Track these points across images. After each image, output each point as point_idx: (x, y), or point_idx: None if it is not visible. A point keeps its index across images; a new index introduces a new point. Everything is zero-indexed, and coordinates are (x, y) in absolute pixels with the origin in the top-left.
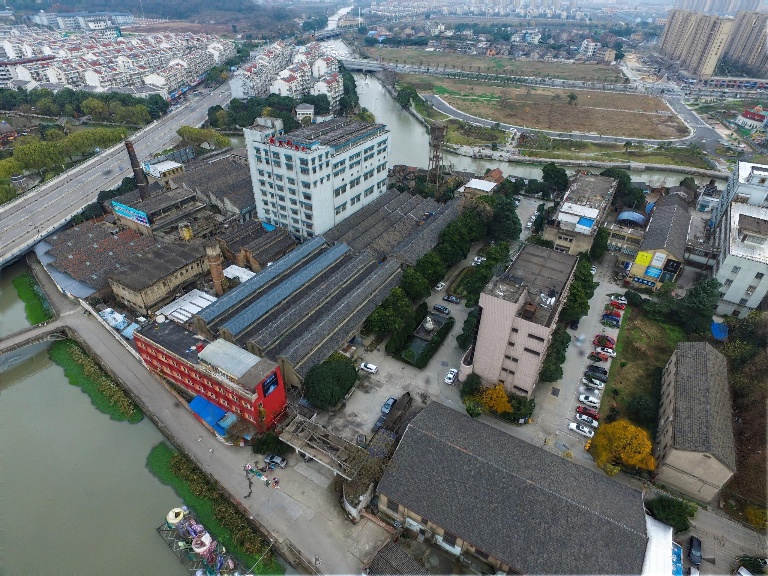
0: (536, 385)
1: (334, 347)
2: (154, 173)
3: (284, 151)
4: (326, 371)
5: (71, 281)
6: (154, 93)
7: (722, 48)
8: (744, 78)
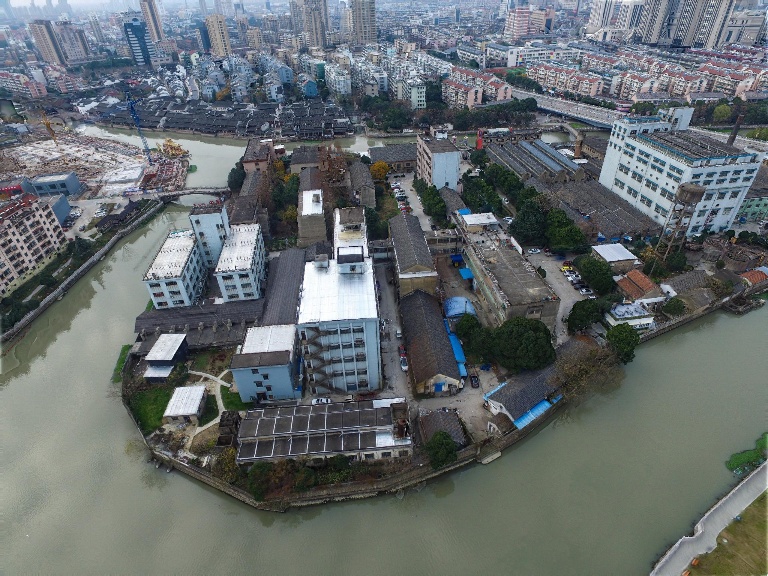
0: None
1: None
2: None
3: None
4: (479, 150)
5: None
6: None
7: None
8: None
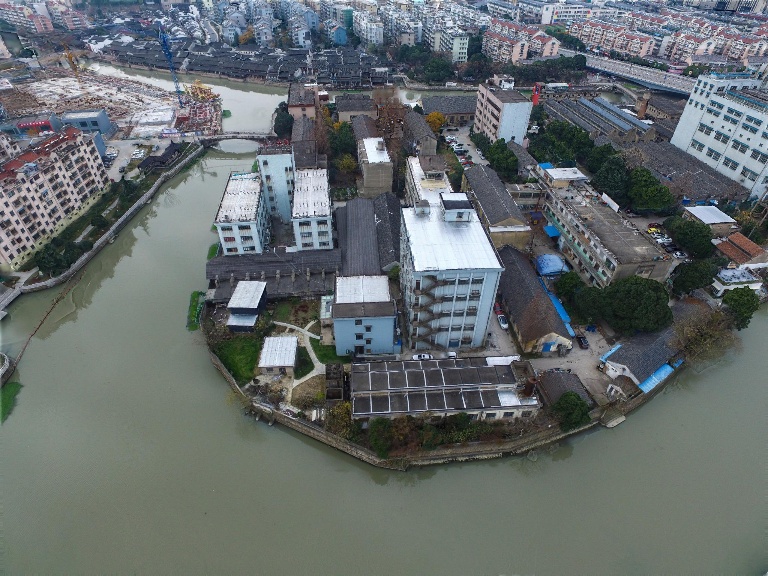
0: None
1: None
2: None
3: None
4: None
5: None
6: None
7: None
8: None
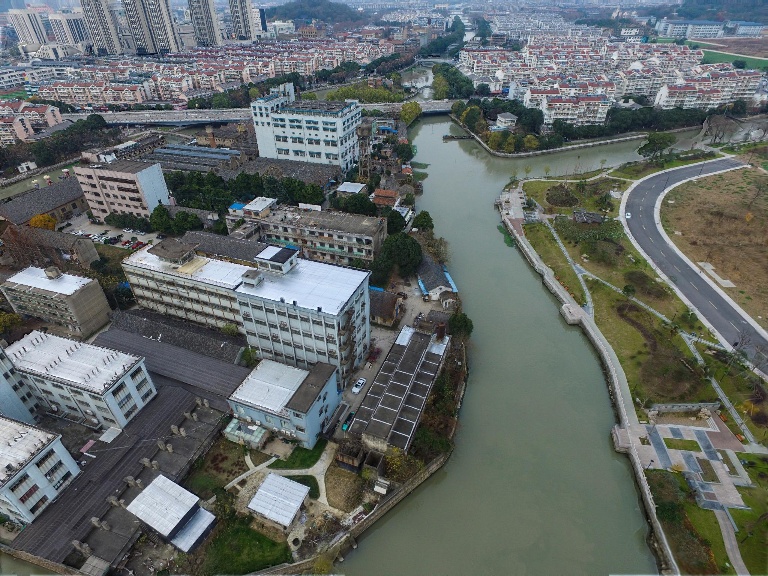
0: (114, 226)
1: None
2: None
3: None
4: None
5: None
6: (485, 83)
7: None
8: None
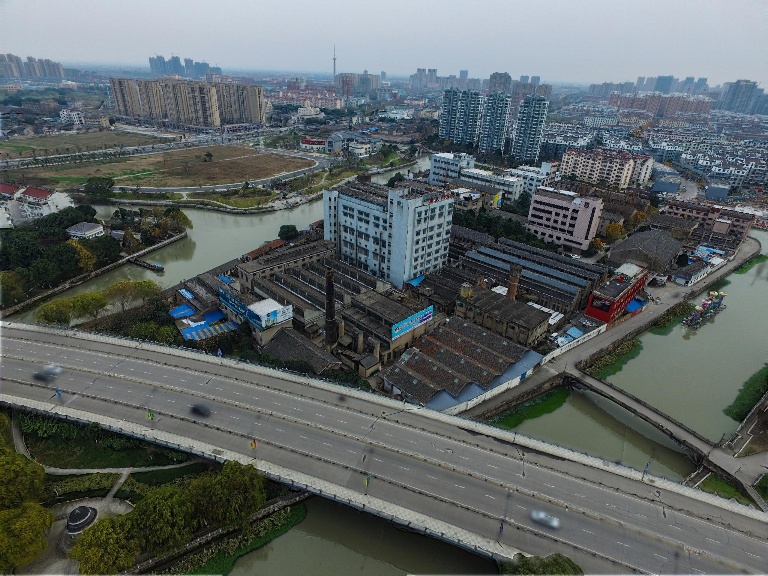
0: None
1: None
2: (283, 317)
3: (439, 204)
4: None
5: (517, 366)
6: None
7: (217, 106)
8: (235, 124)
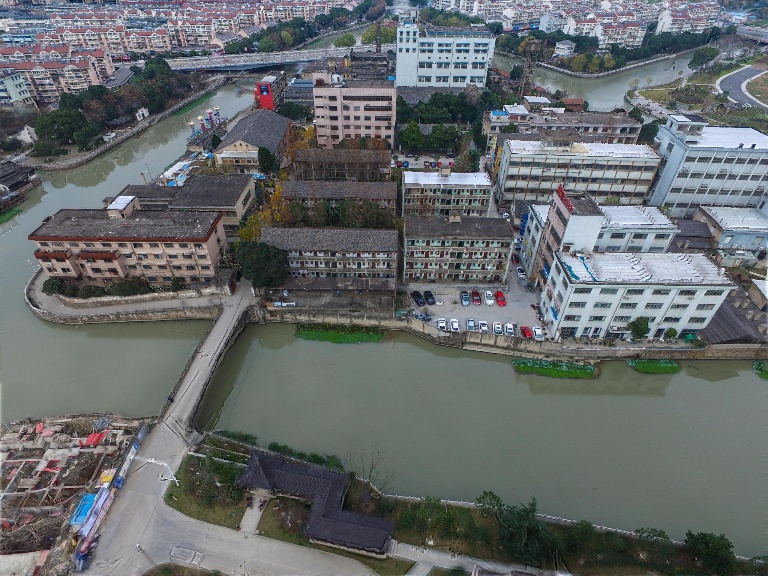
0: None
1: (309, 105)
2: None
3: None
4: (290, 104)
5: None
6: (498, 21)
7: None
8: None
